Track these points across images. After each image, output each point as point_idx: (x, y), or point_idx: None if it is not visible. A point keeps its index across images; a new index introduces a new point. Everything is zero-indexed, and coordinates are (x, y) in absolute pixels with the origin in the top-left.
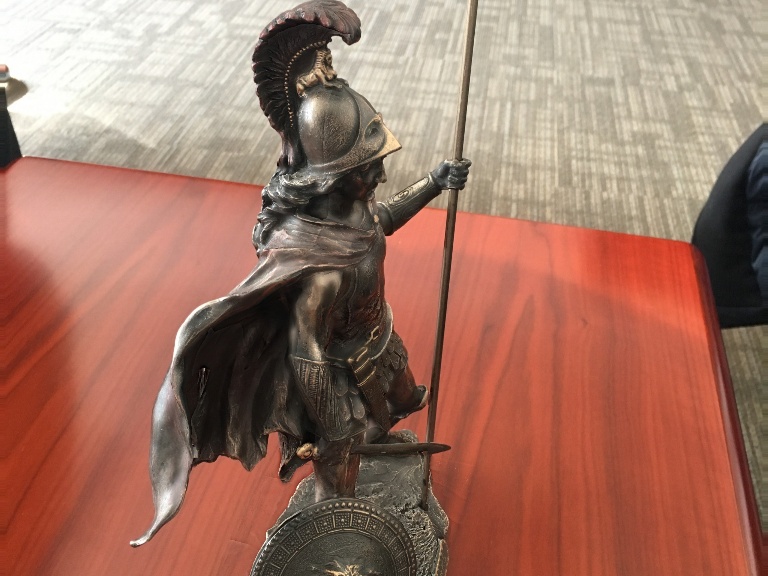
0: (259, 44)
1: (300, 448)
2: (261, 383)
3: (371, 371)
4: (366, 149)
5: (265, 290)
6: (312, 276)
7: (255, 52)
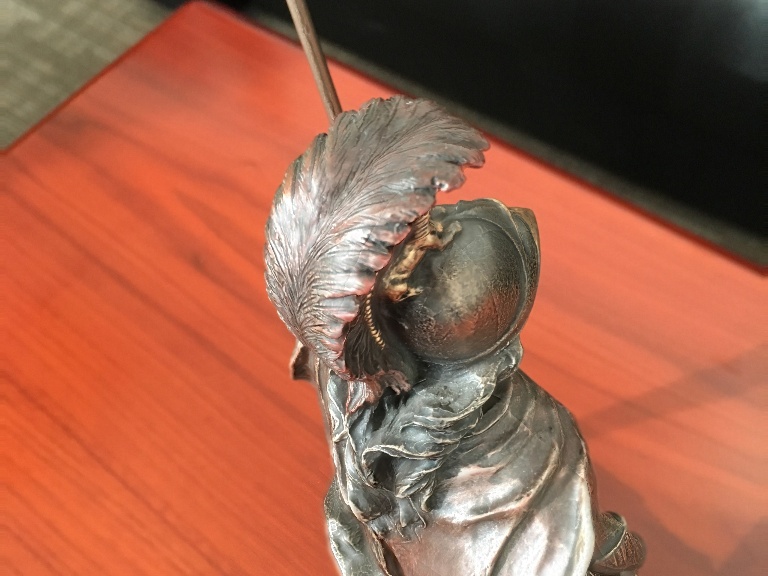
0: (357, 306)
1: None
2: None
3: None
4: (533, 264)
5: None
6: None
7: (344, 323)
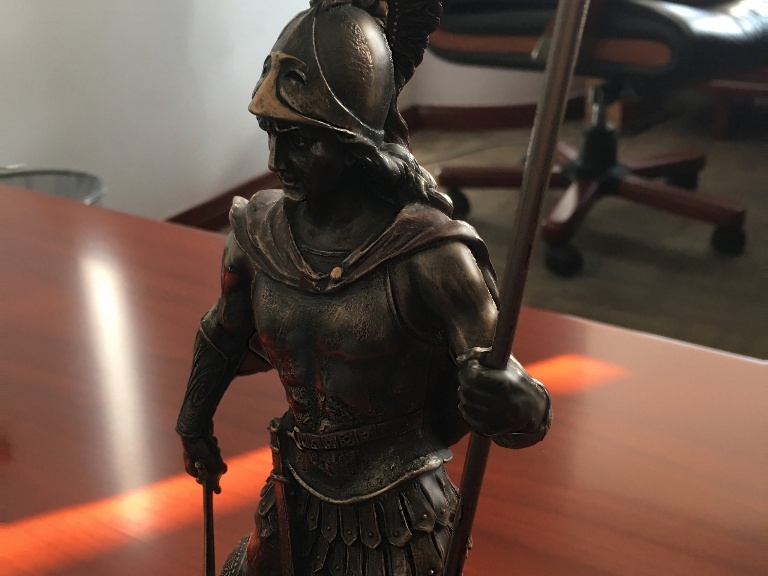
0: None
1: None
2: None
3: (278, 473)
4: None
5: None
6: None
7: None
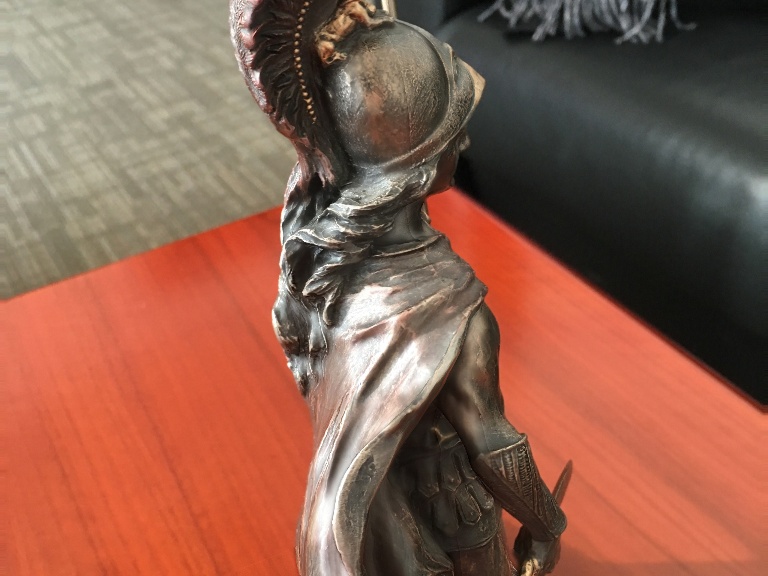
0: None
1: (525, 575)
2: (374, 531)
3: None
4: (463, 99)
5: (443, 379)
6: (470, 324)
7: (253, 9)
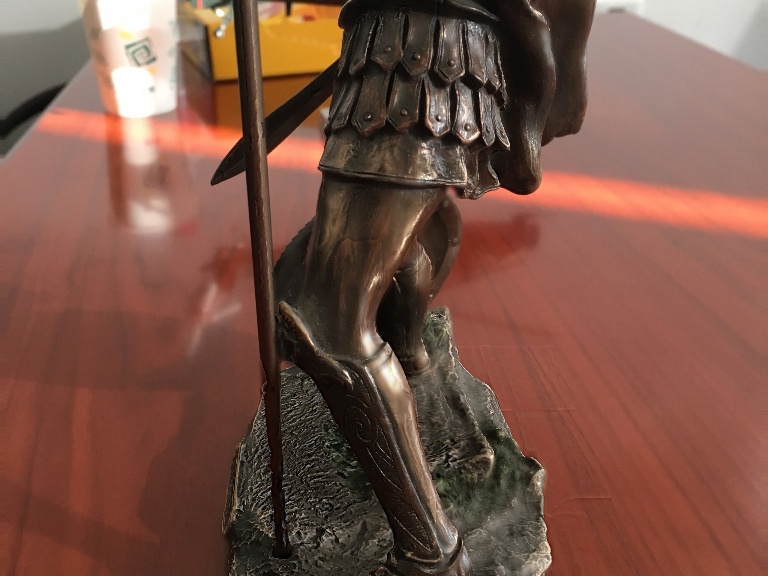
0: None
1: None
2: None
3: None
4: None
5: None
6: None
7: None
